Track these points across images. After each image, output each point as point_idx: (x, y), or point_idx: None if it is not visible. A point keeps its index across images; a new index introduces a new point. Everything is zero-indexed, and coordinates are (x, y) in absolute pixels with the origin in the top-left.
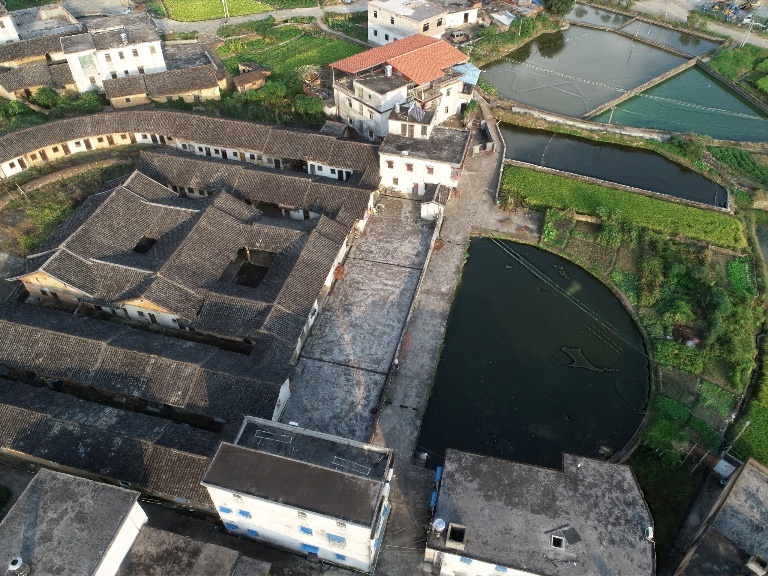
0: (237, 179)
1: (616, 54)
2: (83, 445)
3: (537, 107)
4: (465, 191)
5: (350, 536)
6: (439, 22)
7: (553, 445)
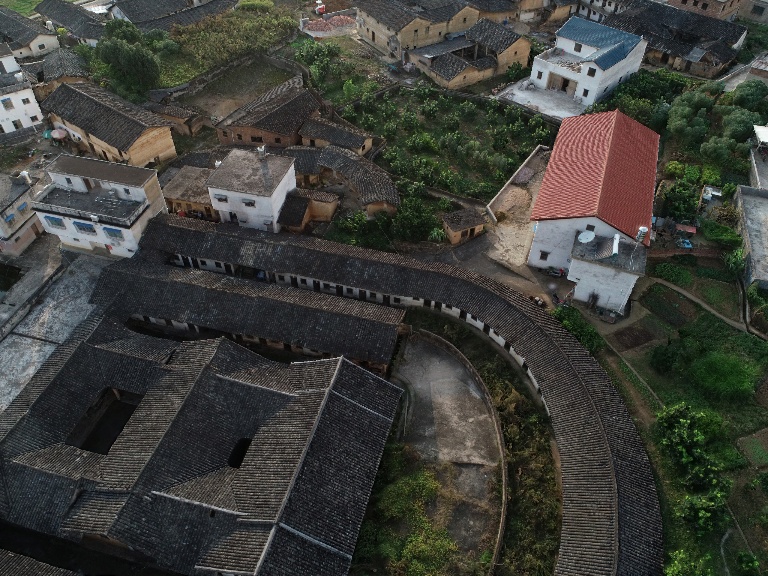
0: None
1: None
2: None
3: None
4: None
5: None
6: None
7: None
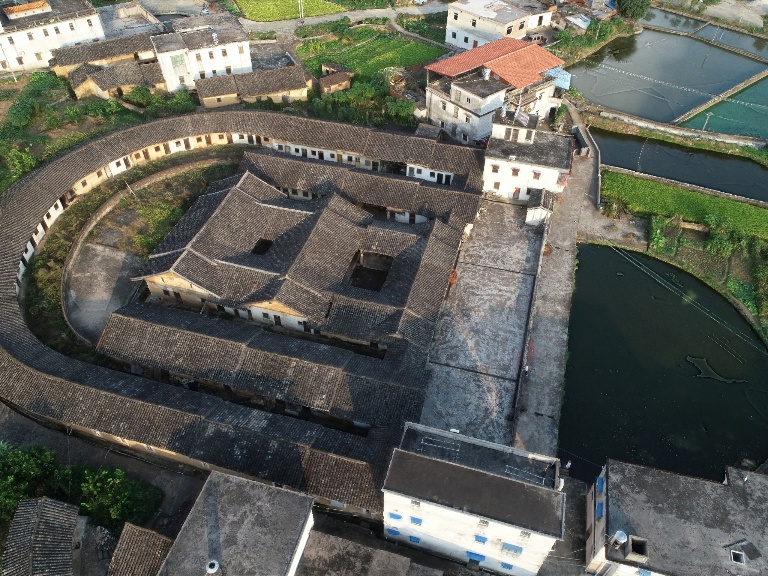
0: (344, 181)
1: (690, 59)
2: (239, 447)
3: (624, 112)
4: (565, 196)
5: (529, 546)
6: (521, 25)
7: (694, 456)
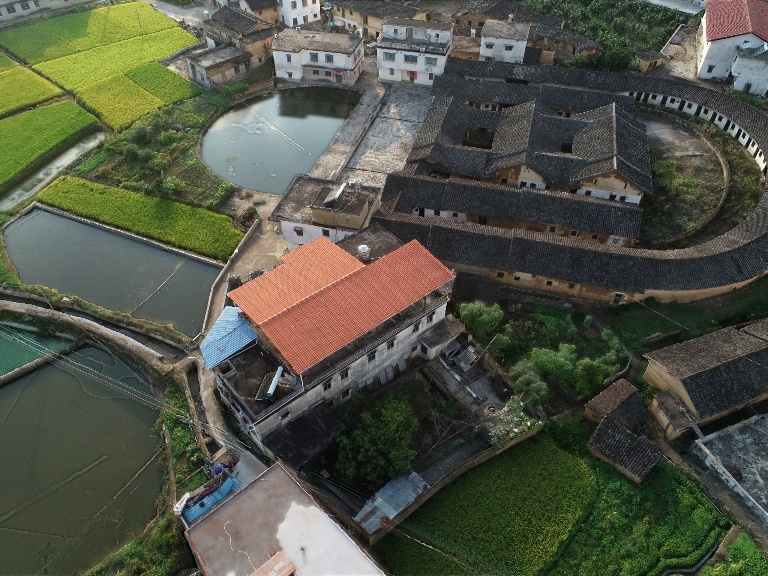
0: None
1: None
2: None
3: None
4: None
5: None
6: None
7: None
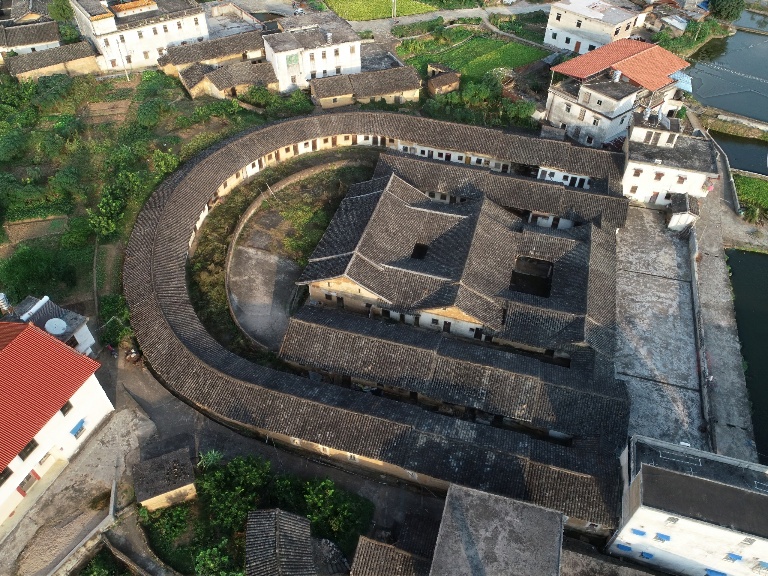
0: (486, 184)
1: None
2: (454, 459)
3: None
4: (701, 201)
5: None
6: (628, 26)
7: None
